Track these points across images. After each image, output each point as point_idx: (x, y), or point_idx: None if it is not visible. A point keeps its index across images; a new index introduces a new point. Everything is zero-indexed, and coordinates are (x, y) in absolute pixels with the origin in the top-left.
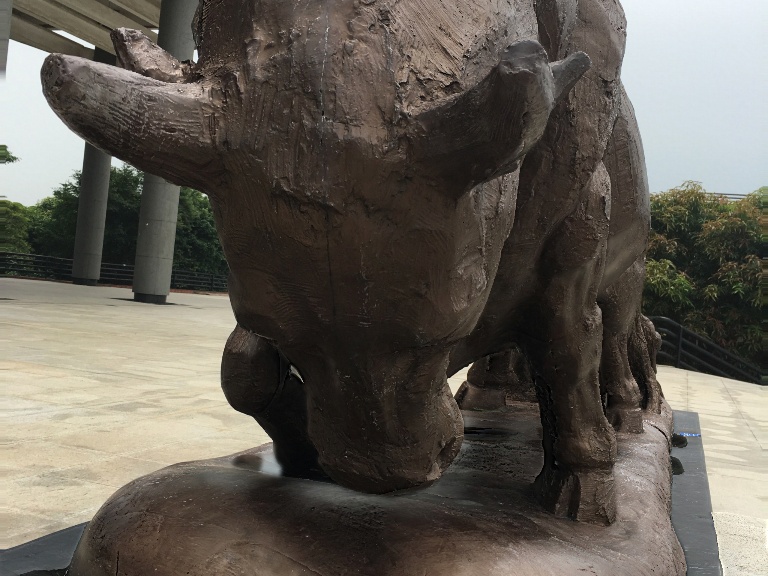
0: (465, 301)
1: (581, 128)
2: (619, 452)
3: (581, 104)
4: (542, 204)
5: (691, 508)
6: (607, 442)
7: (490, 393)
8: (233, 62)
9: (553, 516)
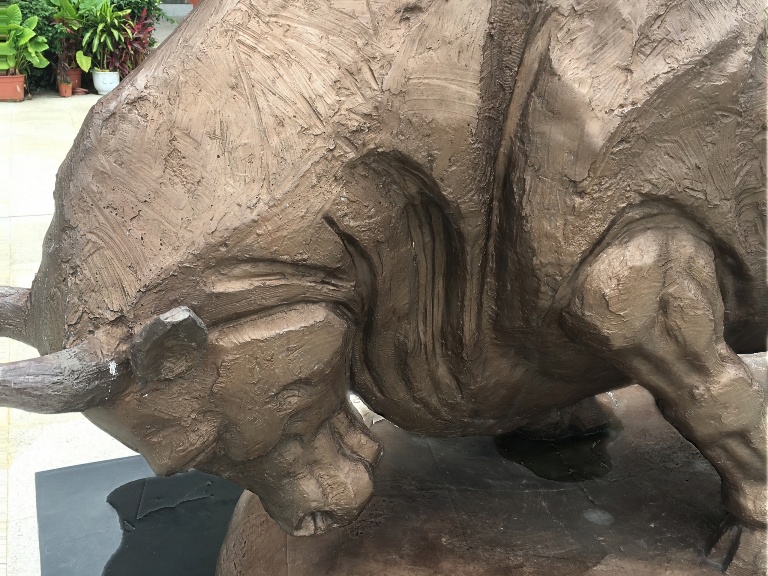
0: (167, 458)
1: (537, 234)
2: None
3: (537, 208)
4: (519, 299)
5: None
6: None
7: None
8: None
9: (703, 558)
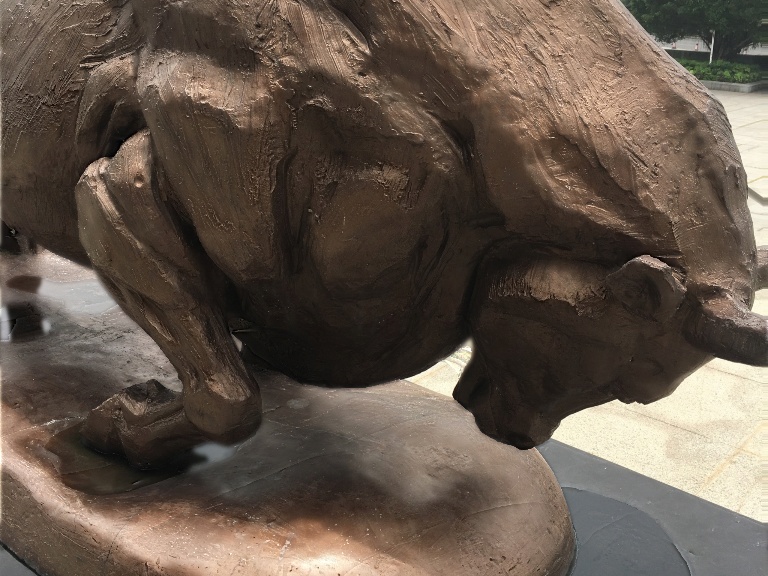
0: None
1: None
2: None
3: None
4: None
5: None
6: None
7: None
8: (741, 278)
9: None
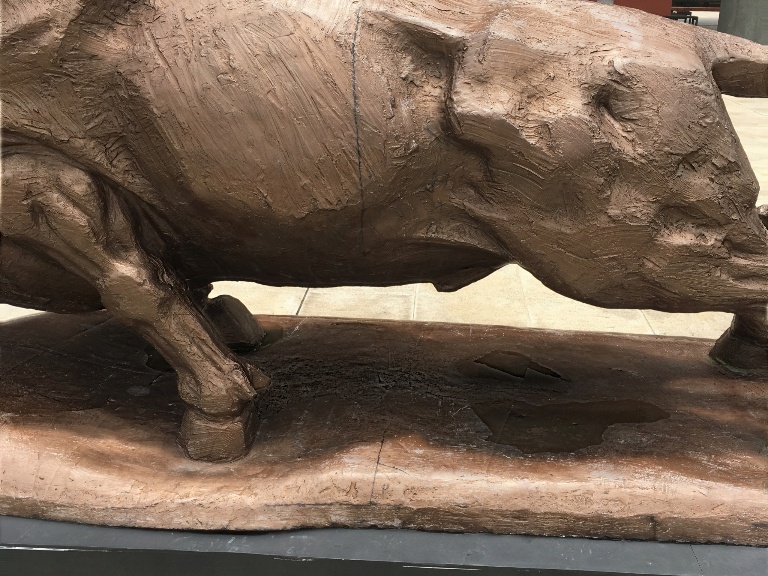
0: None
1: None
2: (541, 452)
3: None
4: None
5: (518, 551)
6: (199, 392)
7: (740, 345)
8: None
9: (176, 430)
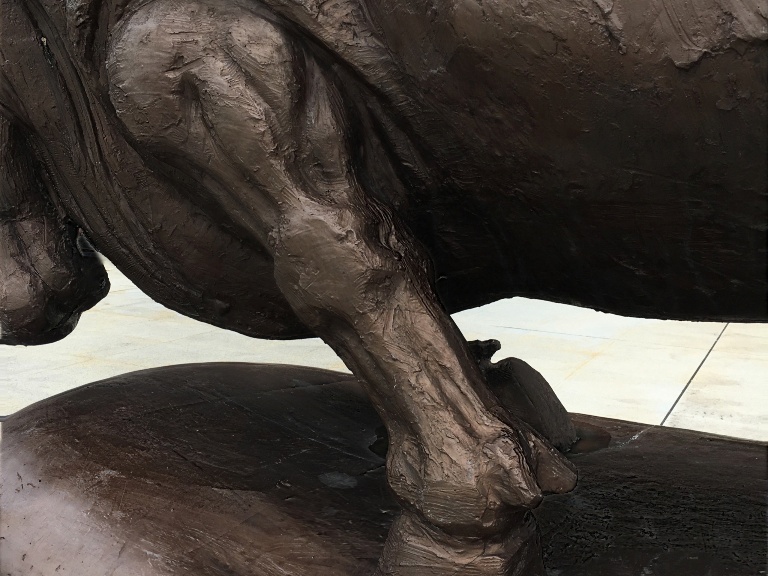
0: None
1: None
2: None
3: None
4: None
5: None
6: (423, 473)
7: None
8: None
9: None
